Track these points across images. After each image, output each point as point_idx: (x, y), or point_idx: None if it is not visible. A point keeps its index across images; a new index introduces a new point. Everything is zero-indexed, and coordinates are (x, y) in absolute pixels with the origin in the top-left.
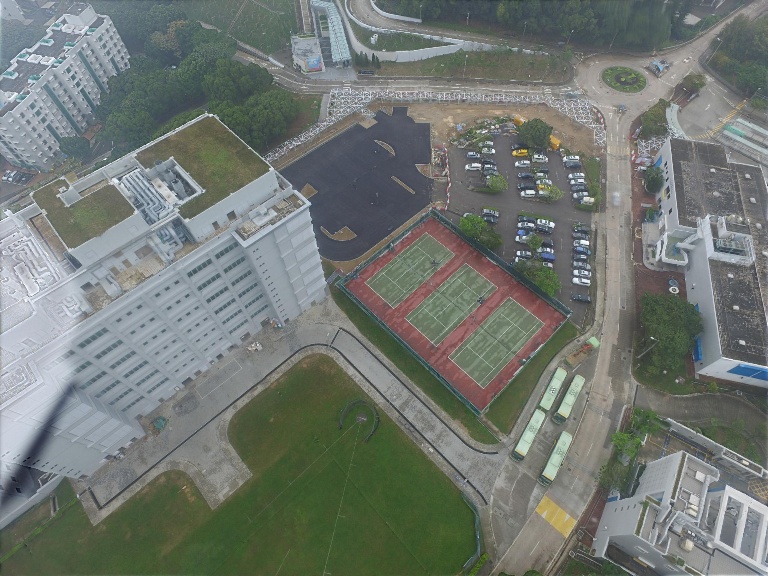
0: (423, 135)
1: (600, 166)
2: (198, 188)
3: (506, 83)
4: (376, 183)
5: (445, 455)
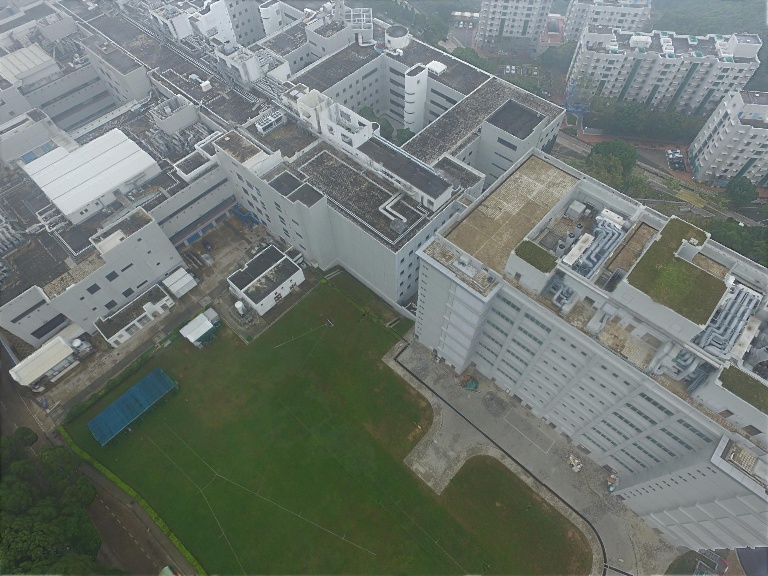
0: None
1: None
2: None
3: None
4: None
5: None
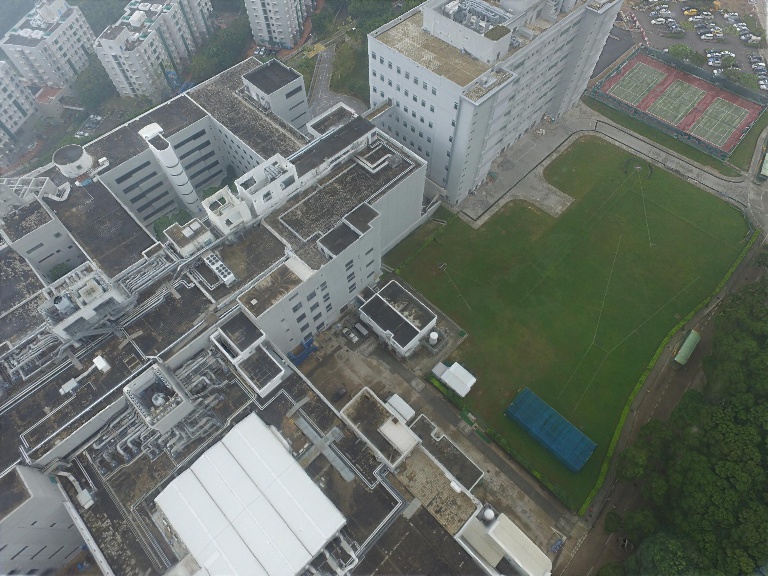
0: None
1: (755, 19)
2: None
3: None
4: None
5: (707, 184)
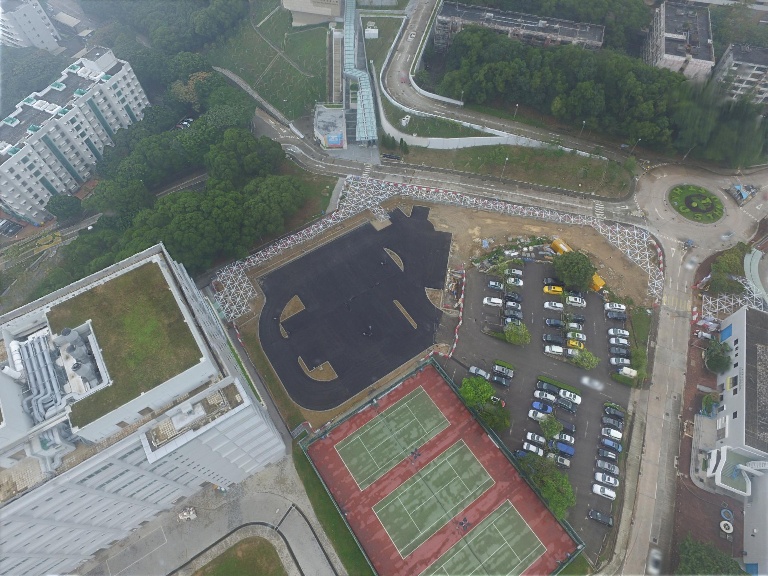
0: (441, 248)
1: (651, 323)
2: (105, 376)
3: (551, 191)
4: (374, 306)
5: None
